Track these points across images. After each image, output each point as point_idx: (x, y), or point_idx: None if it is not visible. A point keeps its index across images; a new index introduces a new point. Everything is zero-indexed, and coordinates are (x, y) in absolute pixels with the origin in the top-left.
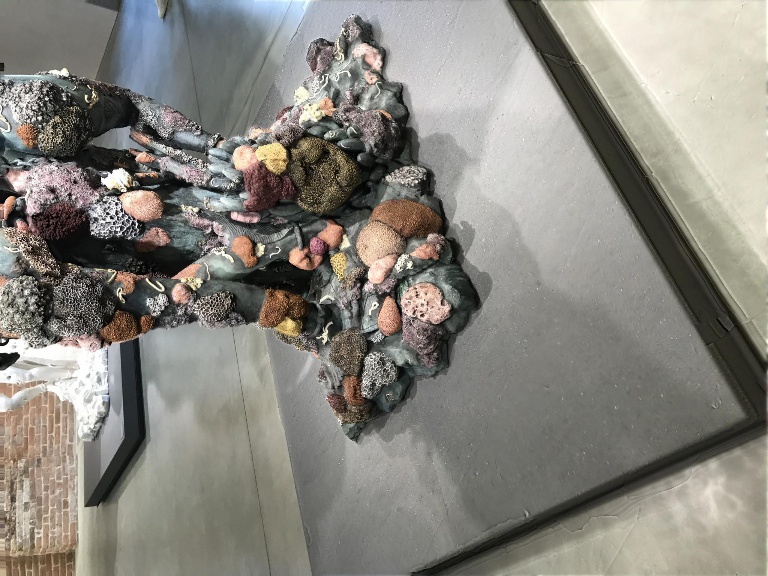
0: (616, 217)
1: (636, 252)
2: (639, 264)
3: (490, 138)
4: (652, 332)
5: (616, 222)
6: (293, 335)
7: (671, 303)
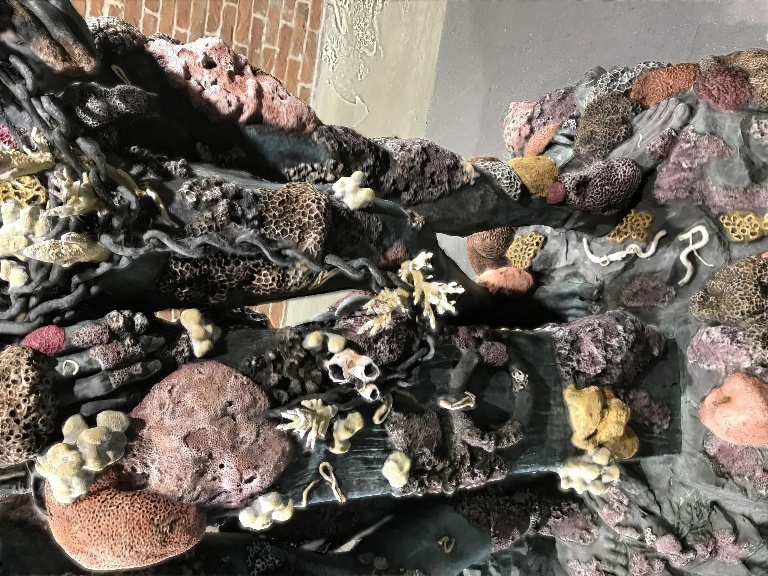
0: (437, 94)
1: (443, 62)
2: (446, 53)
3: (450, 247)
4: (462, 3)
5: (438, 90)
6: (538, 157)
7: (447, 16)
